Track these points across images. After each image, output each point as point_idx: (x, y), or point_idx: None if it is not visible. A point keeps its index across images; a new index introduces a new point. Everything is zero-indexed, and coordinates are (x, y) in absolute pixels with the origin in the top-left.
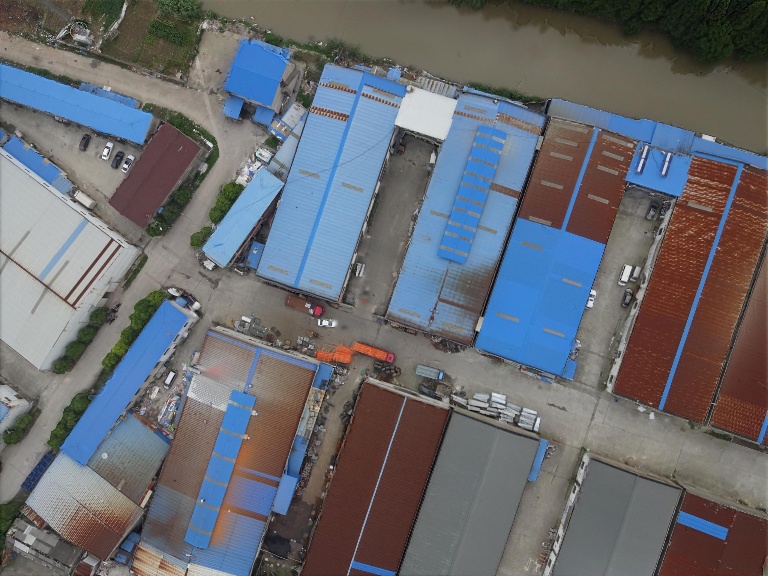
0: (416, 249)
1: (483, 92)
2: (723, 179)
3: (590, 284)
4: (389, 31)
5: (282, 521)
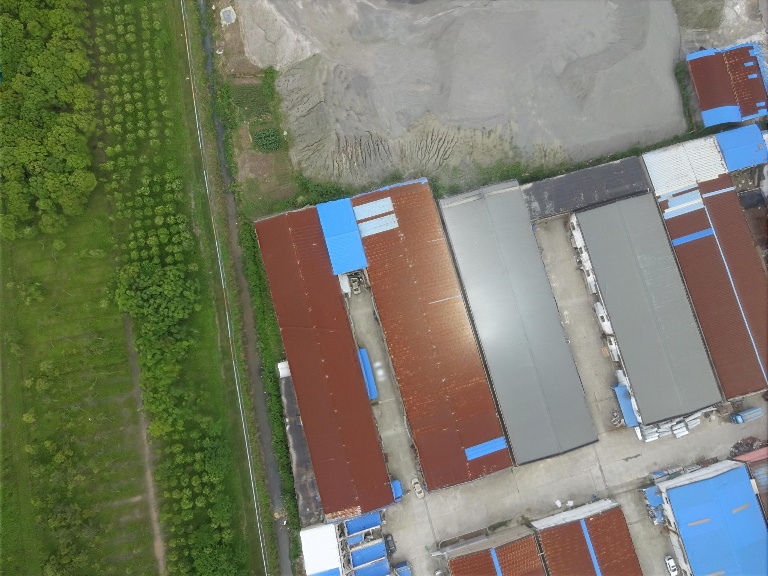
0: None
1: None
2: None
3: None
4: None
5: (761, 220)
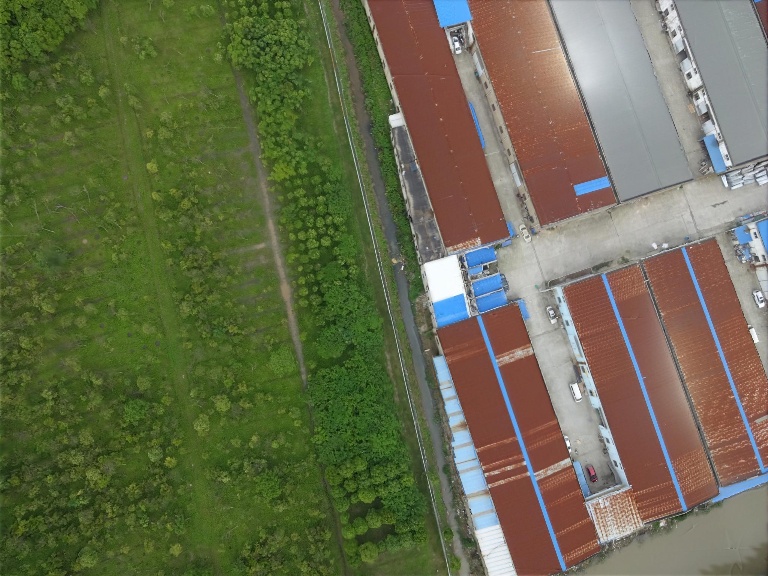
0: None
1: None
2: (766, 451)
3: None
4: None
5: None
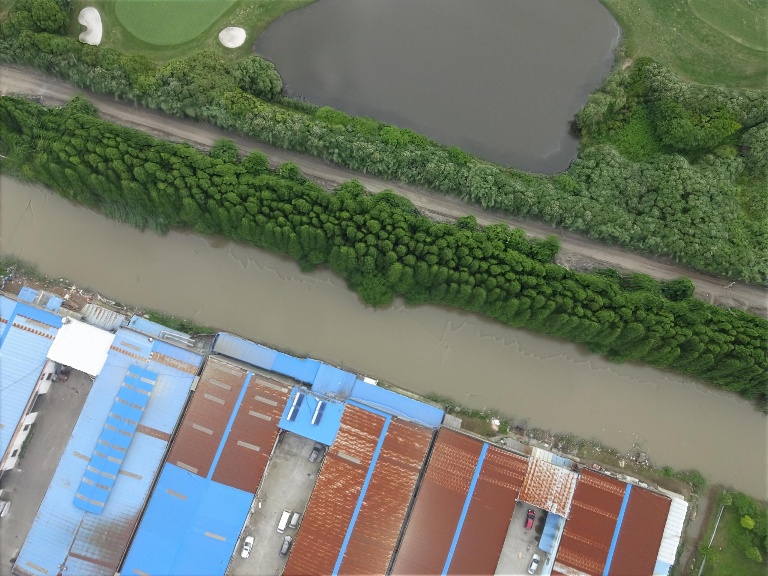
0: (54, 494)
1: (152, 323)
2: (372, 430)
3: (235, 538)
4: (71, 250)
5: None
